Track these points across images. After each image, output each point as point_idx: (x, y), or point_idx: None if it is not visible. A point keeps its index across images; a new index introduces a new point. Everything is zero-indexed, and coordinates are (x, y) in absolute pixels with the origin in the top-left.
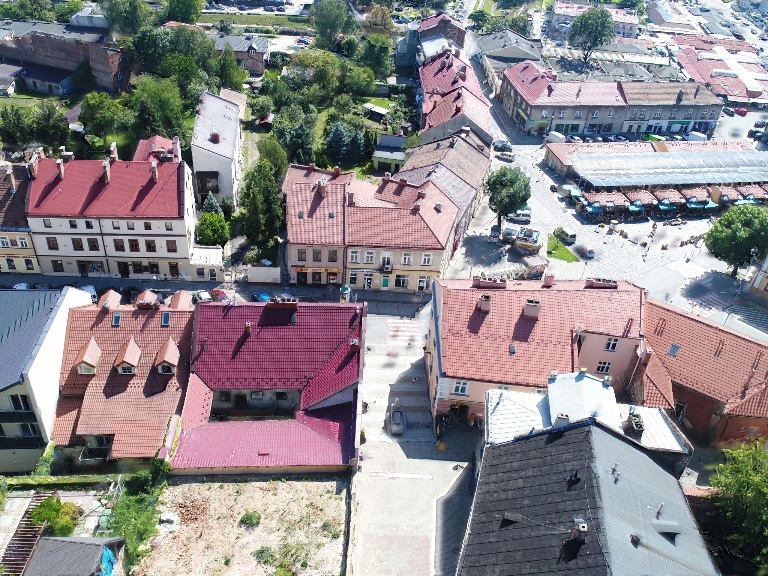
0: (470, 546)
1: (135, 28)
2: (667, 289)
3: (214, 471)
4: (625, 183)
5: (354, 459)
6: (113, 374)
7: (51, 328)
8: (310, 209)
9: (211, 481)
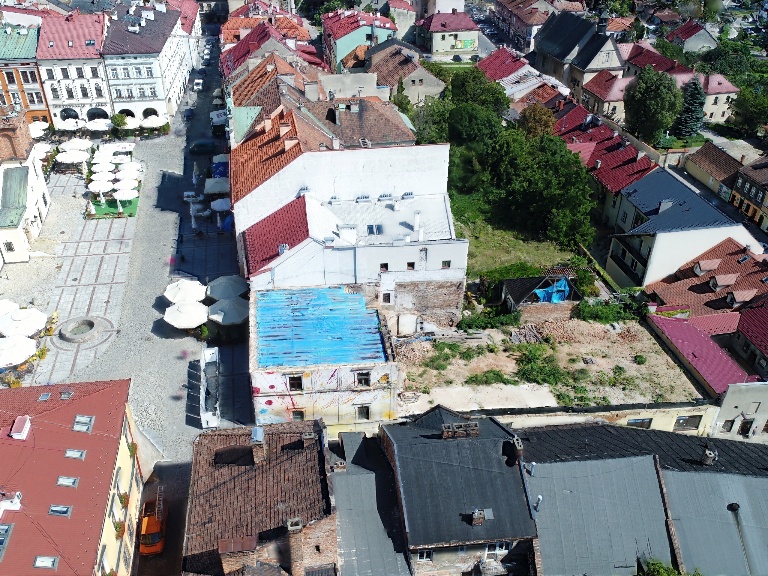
0: (675, 434)
1: None
2: None
3: (663, 336)
4: None
5: (724, 394)
6: (707, 283)
7: (700, 230)
8: None
9: (655, 338)
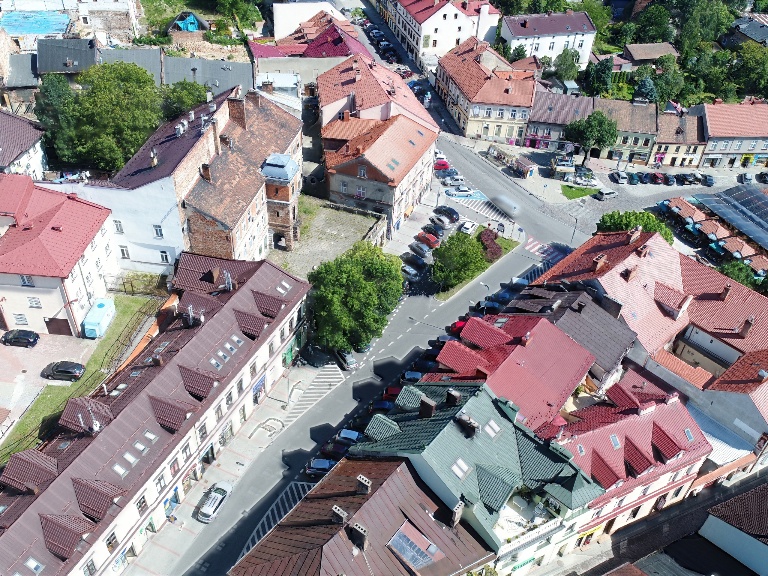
0: None
1: (728, 3)
2: (559, 236)
3: None
4: (719, 211)
5: None
6: None
7: (301, 3)
8: (463, 52)
9: (248, 51)
